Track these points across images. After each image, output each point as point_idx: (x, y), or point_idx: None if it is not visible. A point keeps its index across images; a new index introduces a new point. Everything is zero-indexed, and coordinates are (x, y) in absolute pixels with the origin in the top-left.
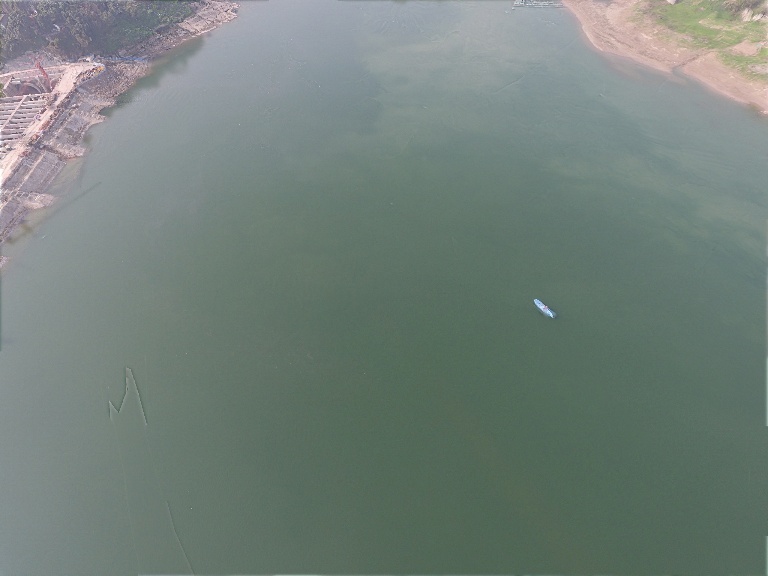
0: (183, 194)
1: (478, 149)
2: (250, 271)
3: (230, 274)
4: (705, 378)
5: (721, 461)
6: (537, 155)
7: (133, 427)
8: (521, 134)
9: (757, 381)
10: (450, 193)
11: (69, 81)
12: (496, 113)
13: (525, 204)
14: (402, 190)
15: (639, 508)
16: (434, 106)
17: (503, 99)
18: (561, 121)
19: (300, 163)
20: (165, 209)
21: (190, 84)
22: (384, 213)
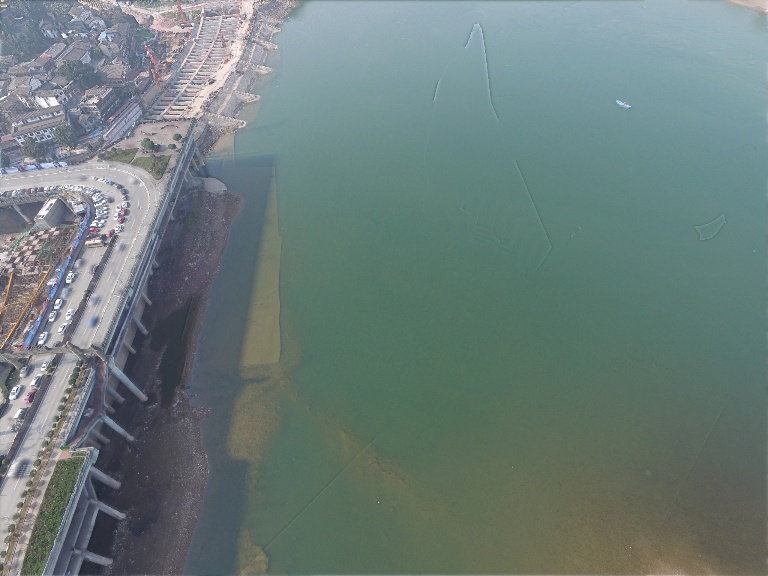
0: (361, 64)
1: (559, 38)
2: (425, 97)
3: (412, 98)
4: (728, 139)
5: (739, 147)
6: (602, 40)
7: (469, 61)
8: (588, 30)
9: (761, 136)
10: (546, 59)
11: (248, 7)
12: (567, 20)
13: (600, 62)
14: (512, 59)
15: (693, 169)
16: (520, 18)
17: (571, 11)
18: (616, 22)
19: (434, 48)
20: (352, 72)
21: (334, 10)
22: (503, 70)
